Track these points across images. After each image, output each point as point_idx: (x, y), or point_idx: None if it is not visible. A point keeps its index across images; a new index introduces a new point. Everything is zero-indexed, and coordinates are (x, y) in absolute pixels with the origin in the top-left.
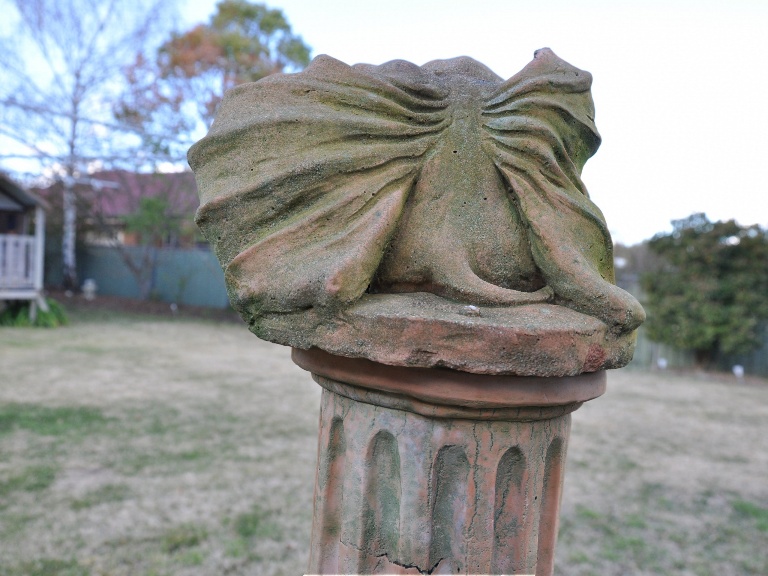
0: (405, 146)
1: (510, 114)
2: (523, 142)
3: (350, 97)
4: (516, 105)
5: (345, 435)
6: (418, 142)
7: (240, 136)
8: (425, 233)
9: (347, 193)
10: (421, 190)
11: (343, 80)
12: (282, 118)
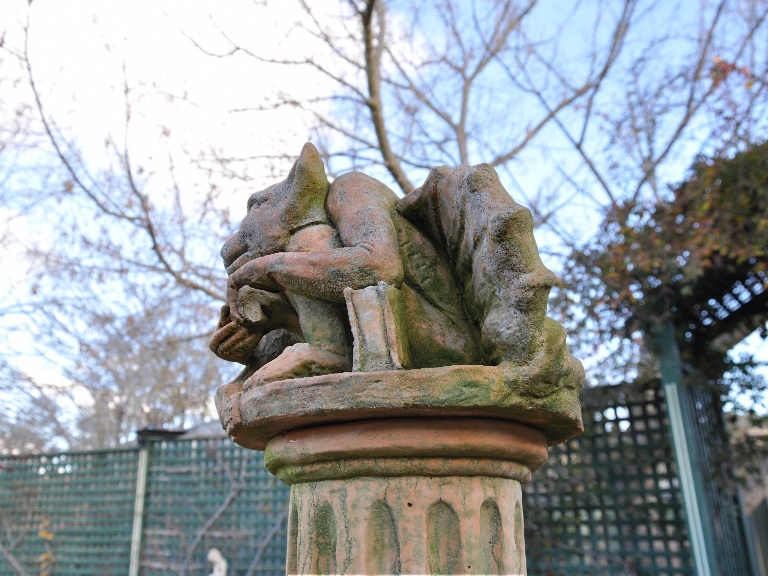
0: None
1: None
2: None
3: None
4: None
5: (502, 514)
6: None
7: None
8: None
9: None
10: None
11: None
12: None
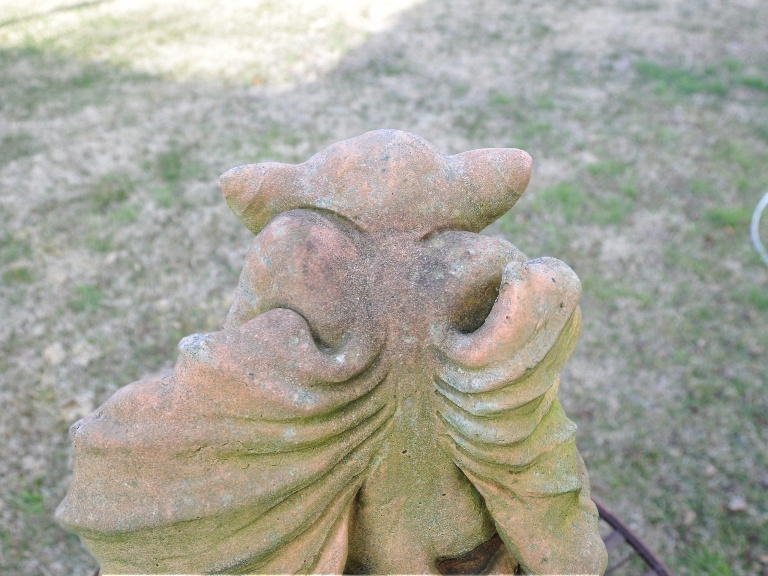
0: (342, 475)
1: (474, 417)
2: (491, 458)
3: (259, 444)
4: (482, 412)
5: None
6: (357, 459)
7: (126, 535)
8: (377, 541)
9: (284, 571)
10: (367, 496)
11: (242, 413)
12: (177, 518)
